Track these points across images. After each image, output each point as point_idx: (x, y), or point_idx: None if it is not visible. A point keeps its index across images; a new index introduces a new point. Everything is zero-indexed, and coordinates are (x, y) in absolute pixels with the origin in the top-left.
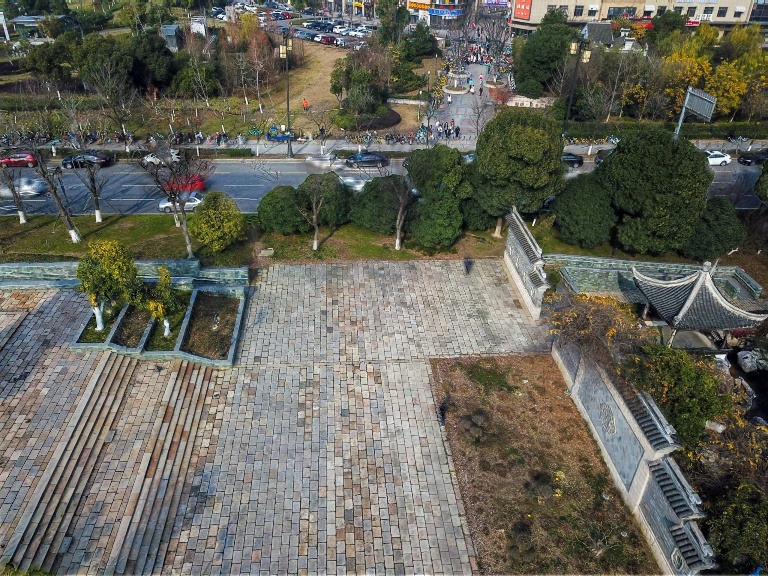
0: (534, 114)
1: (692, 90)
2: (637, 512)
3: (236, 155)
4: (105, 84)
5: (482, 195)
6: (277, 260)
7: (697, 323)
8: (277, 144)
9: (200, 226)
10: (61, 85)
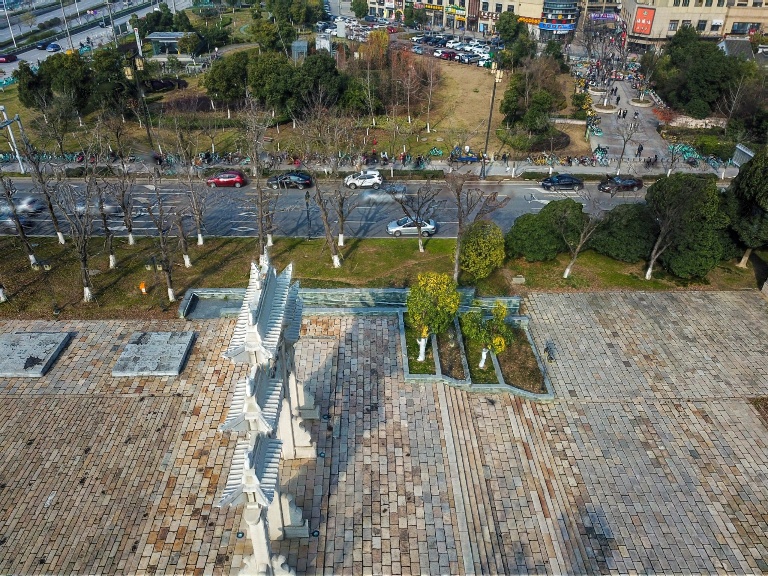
0: None
1: None
2: None
3: None
4: (315, 107)
5: (746, 227)
6: (532, 288)
7: None
8: (461, 165)
9: (468, 254)
10: None
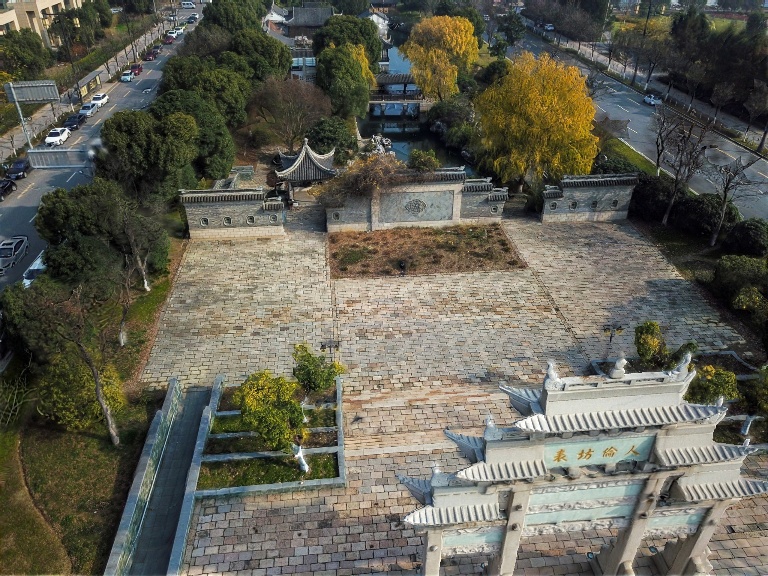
0: (125, 113)
1: (14, 84)
2: (461, 222)
3: None
4: None
5: (154, 198)
6: (132, 376)
7: None
8: None
9: None
10: None
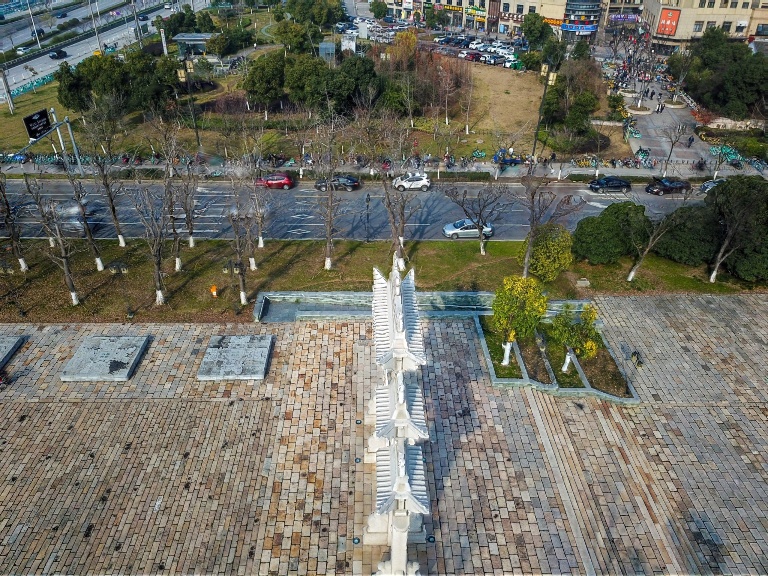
0: None
1: None
2: None
3: (476, 179)
4: (364, 109)
5: None
6: (598, 291)
7: None
8: (505, 167)
9: (536, 257)
10: (318, 110)
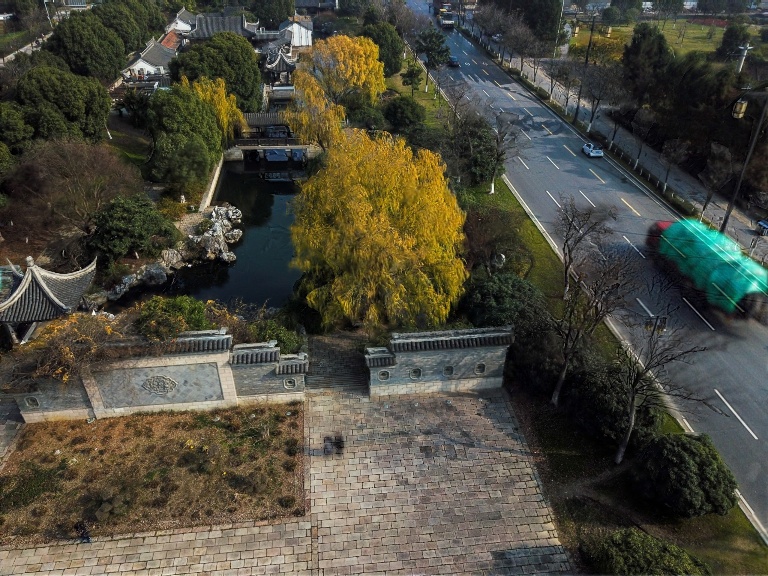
0: None
1: None
2: (240, 401)
3: None
4: None
5: None
6: None
7: (73, 301)
8: None
9: None
10: None
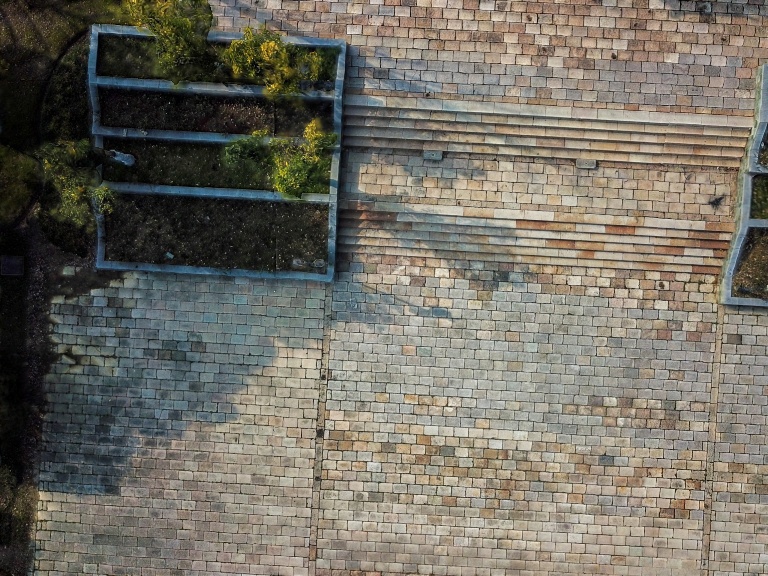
0: None
1: None
2: None
3: None
4: None
5: None
6: None
7: None
8: None
9: None
10: None
